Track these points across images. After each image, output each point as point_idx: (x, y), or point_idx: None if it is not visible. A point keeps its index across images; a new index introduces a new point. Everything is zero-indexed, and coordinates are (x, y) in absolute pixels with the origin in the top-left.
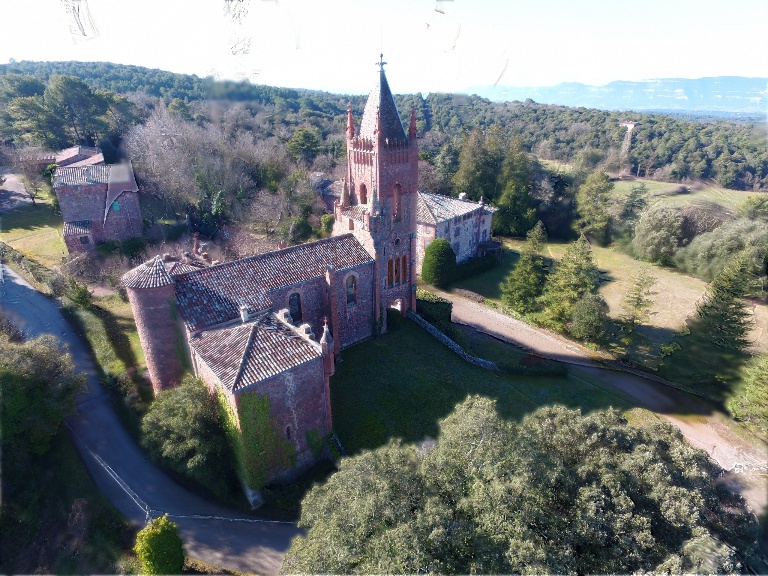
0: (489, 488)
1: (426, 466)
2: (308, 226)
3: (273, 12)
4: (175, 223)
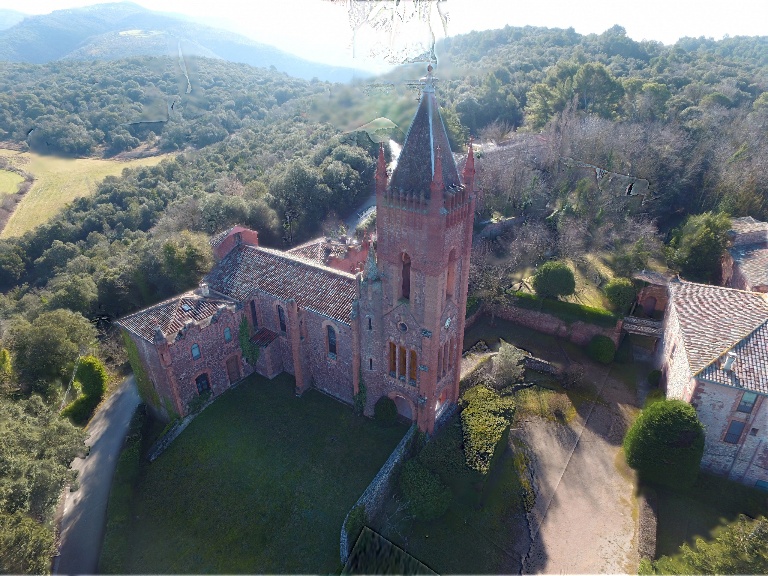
0: None
1: None
2: (563, 278)
3: None
4: (477, 220)
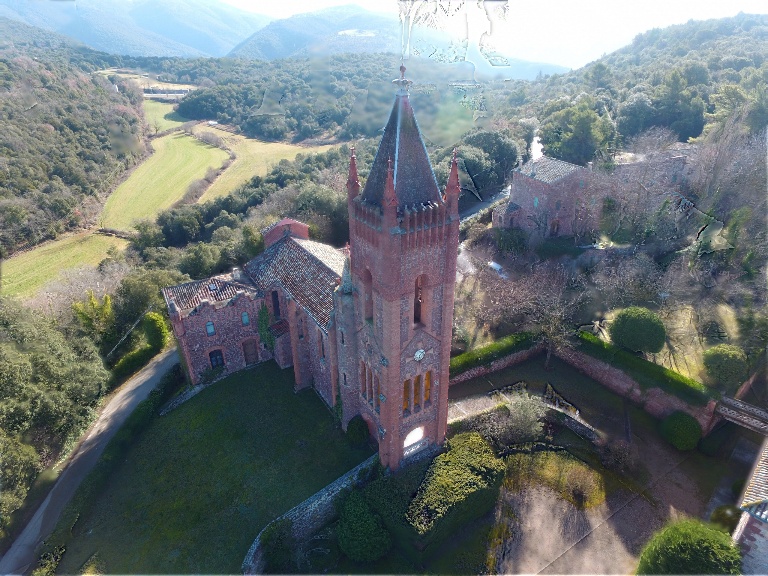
0: None
1: None
2: (645, 330)
3: (471, 3)
4: None
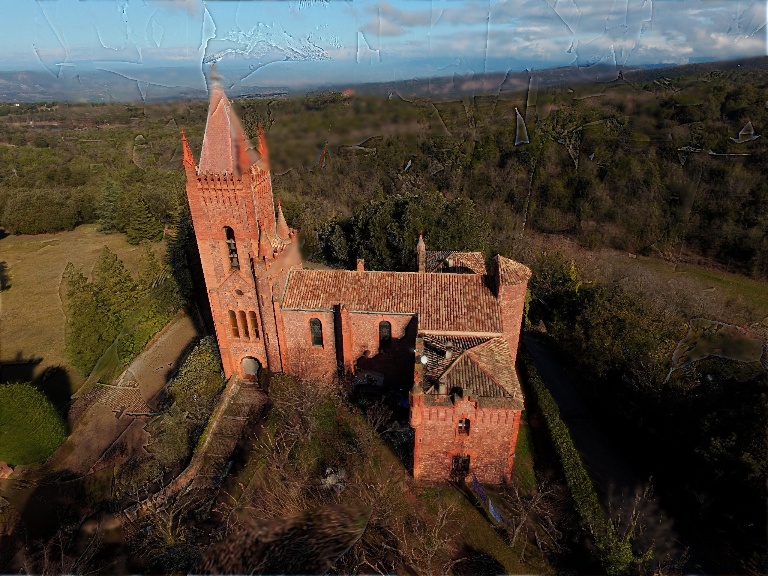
0: (441, 196)
1: (444, 209)
2: None
3: None
4: None
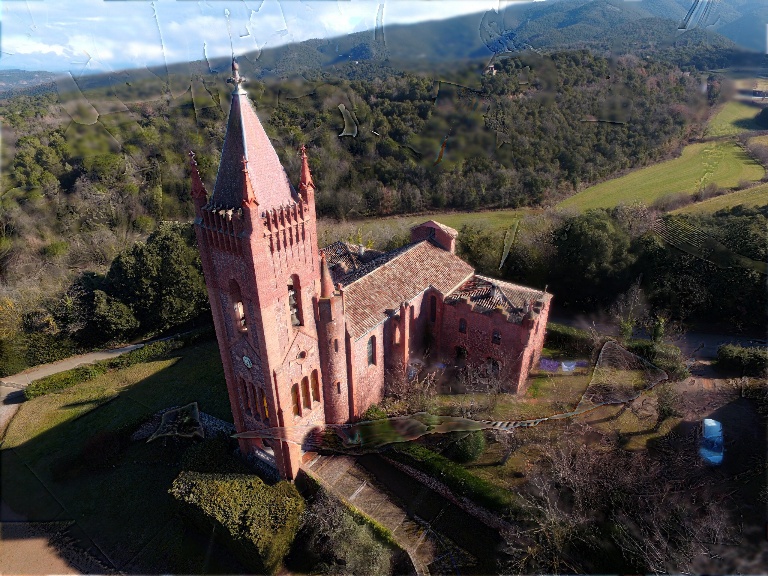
0: None
1: None
2: None
3: None
4: None
